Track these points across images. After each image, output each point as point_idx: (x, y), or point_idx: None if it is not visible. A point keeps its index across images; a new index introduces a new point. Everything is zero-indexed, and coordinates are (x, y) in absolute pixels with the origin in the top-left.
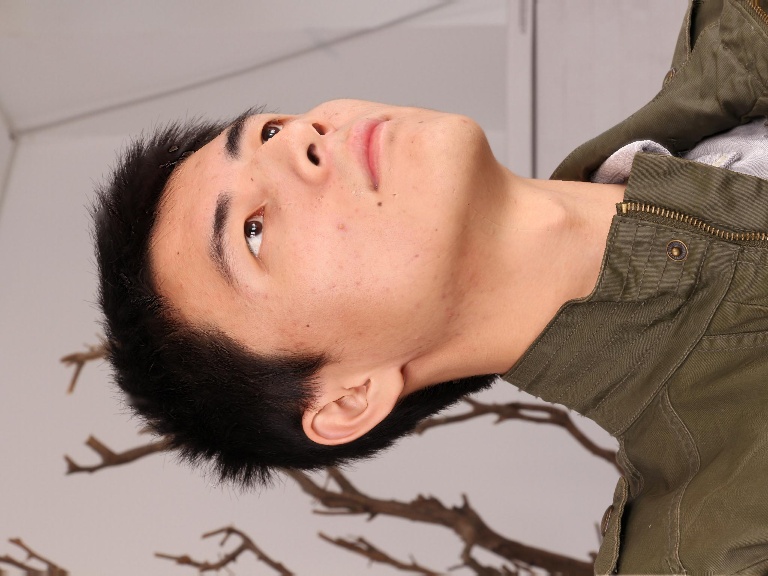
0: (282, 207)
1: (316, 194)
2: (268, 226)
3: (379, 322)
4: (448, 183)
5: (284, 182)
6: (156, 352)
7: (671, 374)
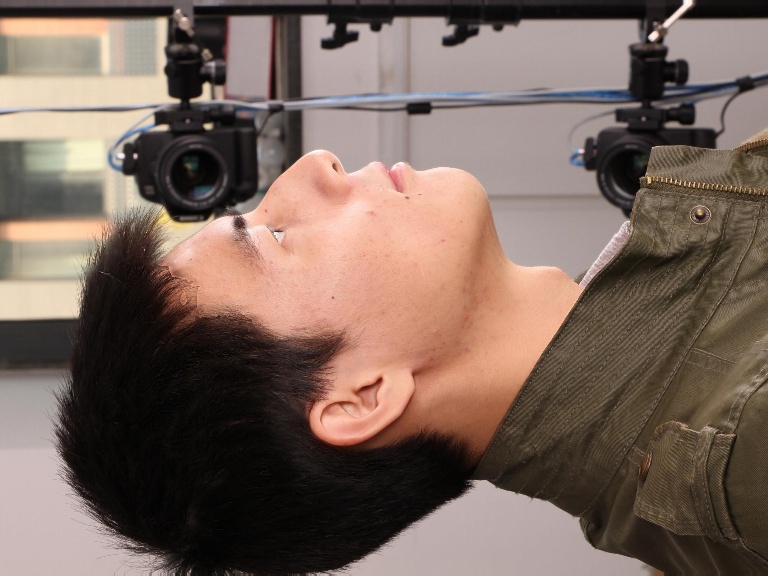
0: (302, 218)
1: (338, 203)
2: (290, 227)
3: (404, 299)
4: (470, 189)
5: (304, 199)
6: (161, 343)
7: (698, 334)
